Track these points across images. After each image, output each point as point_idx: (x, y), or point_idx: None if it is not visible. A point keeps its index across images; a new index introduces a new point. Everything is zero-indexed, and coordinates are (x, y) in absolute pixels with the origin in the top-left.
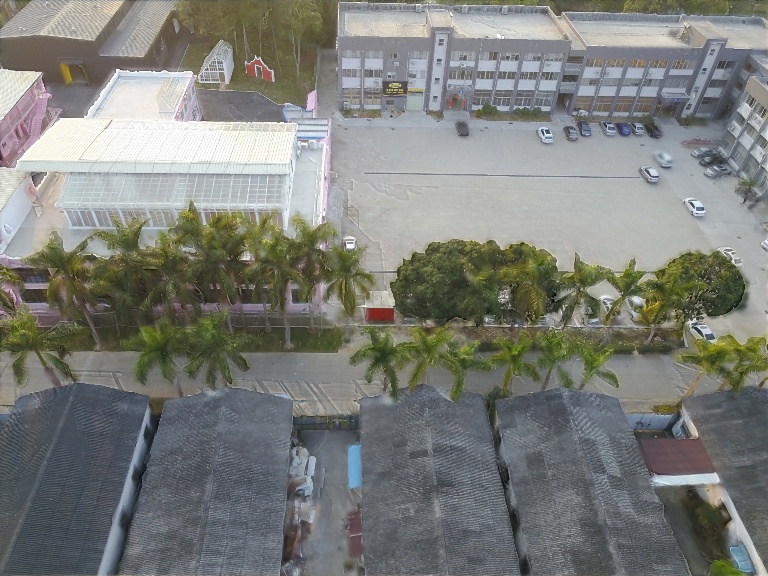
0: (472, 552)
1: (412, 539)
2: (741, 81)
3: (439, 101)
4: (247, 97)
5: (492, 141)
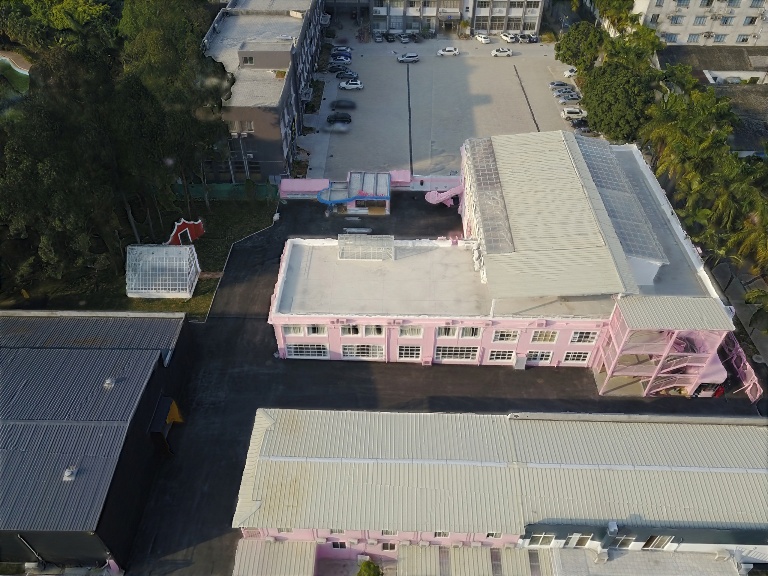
0: None
1: None
2: None
3: None
4: (247, 251)
5: (356, 110)
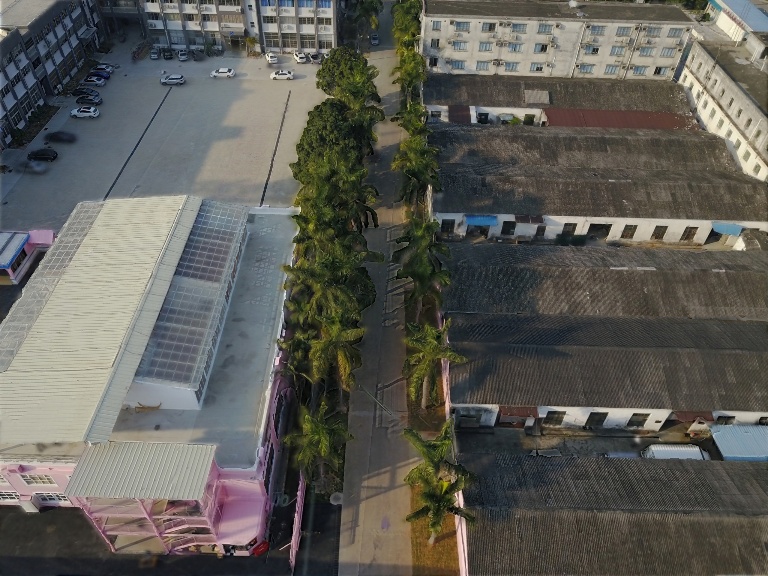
0: None
1: (536, 191)
2: None
3: None
4: None
5: (74, 144)
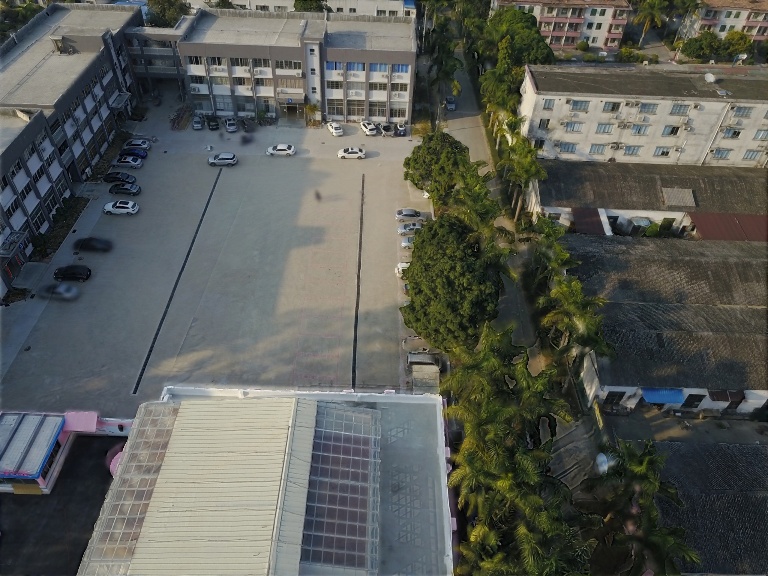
0: (723, 322)
1: (730, 353)
2: (134, 57)
3: (0, 281)
4: None
5: (110, 254)
